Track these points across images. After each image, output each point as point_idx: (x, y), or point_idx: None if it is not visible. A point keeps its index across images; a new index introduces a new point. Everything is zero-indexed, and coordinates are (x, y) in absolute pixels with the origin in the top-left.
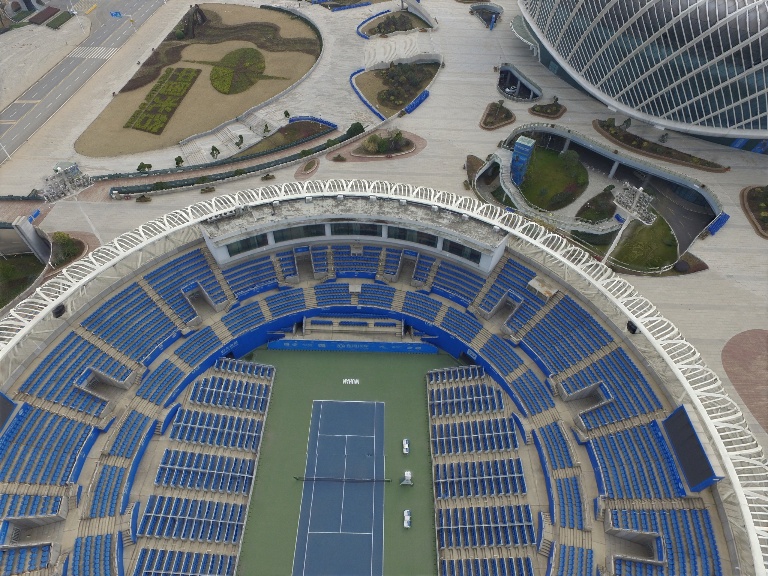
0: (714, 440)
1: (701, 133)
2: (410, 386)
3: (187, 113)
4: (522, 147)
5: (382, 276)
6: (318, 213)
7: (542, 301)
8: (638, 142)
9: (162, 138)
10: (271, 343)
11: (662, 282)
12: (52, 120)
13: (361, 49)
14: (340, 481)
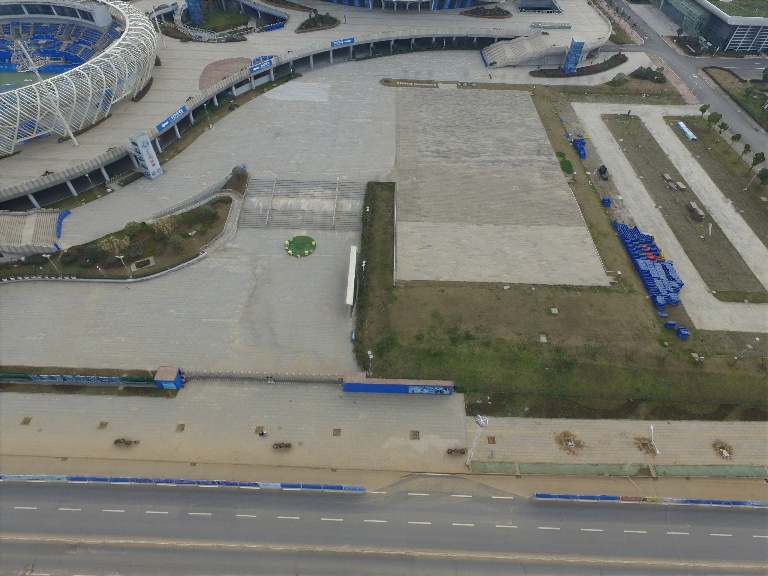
0: None
1: None
2: None
3: None
4: None
5: None
6: None
7: (119, 36)
8: None
9: None
10: None
11: (213, 44)
12: None
13: None
14: None
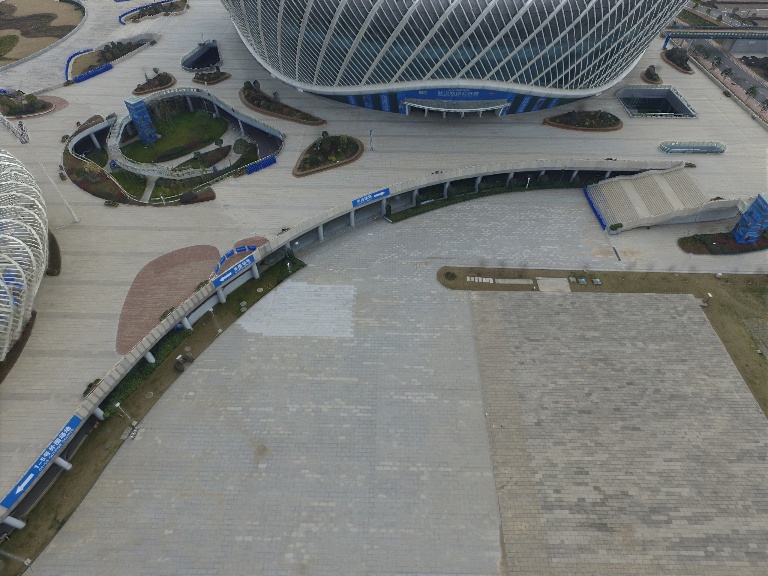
0: None
1: (321, 92)
2: None
3: None
4: (129, 105)
5: None
6: None
7: None
8: (259, 101)
9: None
10: None
11: (159, 211)
12: None
13: (109, 33)
14: None
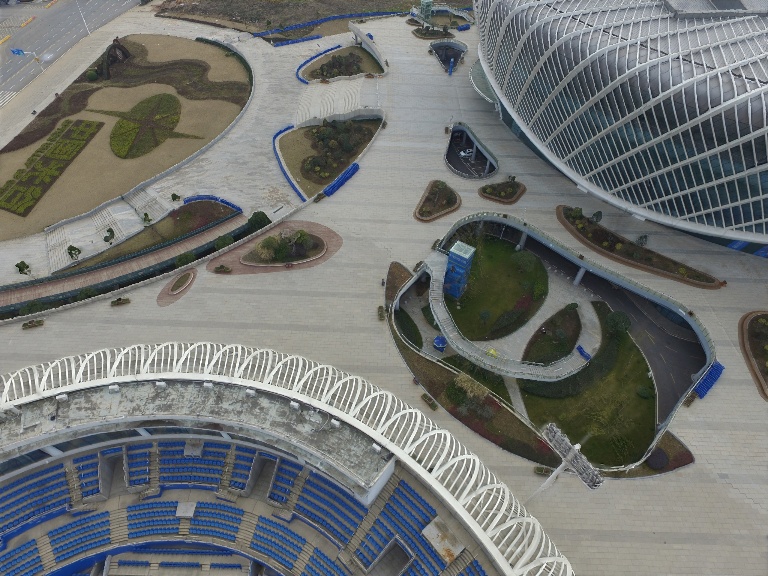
0: None
1: (690, 230)
2: None
3: (68, 185)
4: (458, 258)
5: (223, 494)
6: (121, 414)
7: (441, 562)
8: (610, 243)
9: (27, 222)
10: None
11: (628, 489)
12: None
13: (296, 98)
14: None
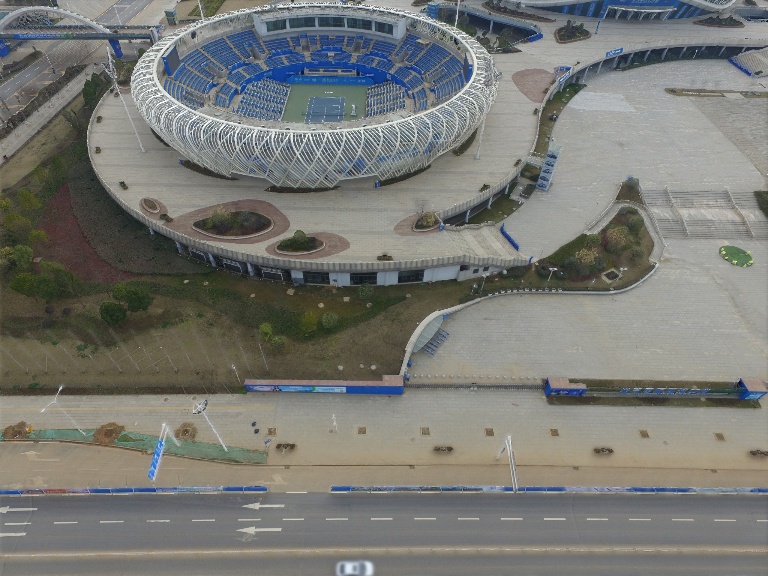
0: (473, 57)
1: (544, 5)
2: (359, 94)
3: (227, 9)
4: (431, 7)
5: None
6: (311, 11)
7: (423, 48)
8: (505, 9)
9: None
10: (288, 79)
11: None
12: (141, 14)
13: None
14: (323, 115)
